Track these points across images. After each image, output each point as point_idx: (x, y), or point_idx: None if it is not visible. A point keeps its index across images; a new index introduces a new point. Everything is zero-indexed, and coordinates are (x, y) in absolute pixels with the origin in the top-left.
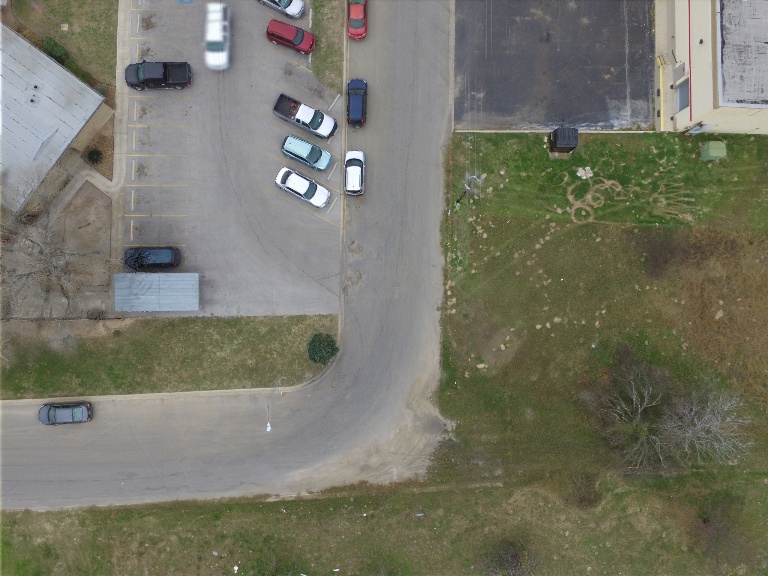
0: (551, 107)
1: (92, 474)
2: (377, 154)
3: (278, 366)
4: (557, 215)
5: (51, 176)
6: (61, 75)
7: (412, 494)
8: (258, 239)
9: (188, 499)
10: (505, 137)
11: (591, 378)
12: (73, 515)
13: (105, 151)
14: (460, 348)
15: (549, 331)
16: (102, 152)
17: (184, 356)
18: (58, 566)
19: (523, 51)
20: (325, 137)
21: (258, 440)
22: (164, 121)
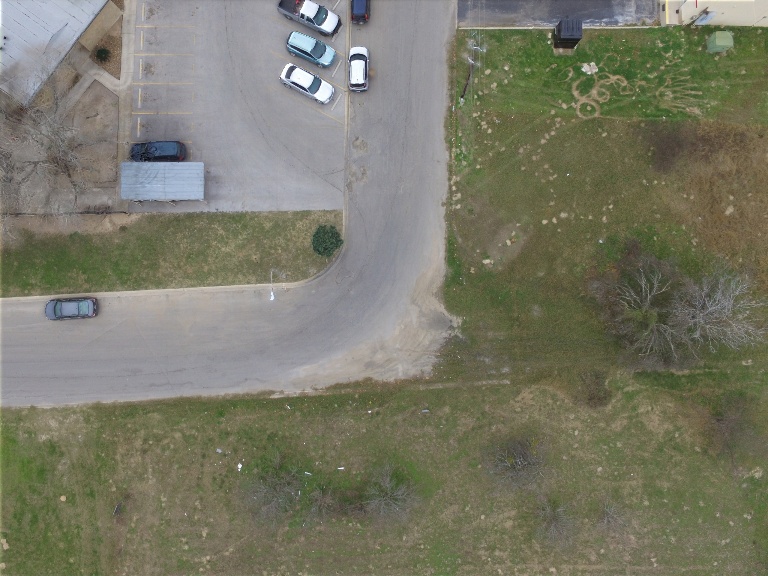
0: (555, 4)
1: (97, 370)
2: (381, 51)
3: (282, 261)
4: (562, 110)
5: (60, 71)
6: None
7: (418, 391)
8: (263, 136)
9: (192, 395)
10: (509, 33)
11: (599, 273)
12: (78, 412)
13: (113, 51)
14: (465, 243)
15: (555, 226)
16: (110, 51)
17: (189, 252)
18: (62, 464)
19: None
20: (329, 33)
21: (262, 336)
22: (171, 21)
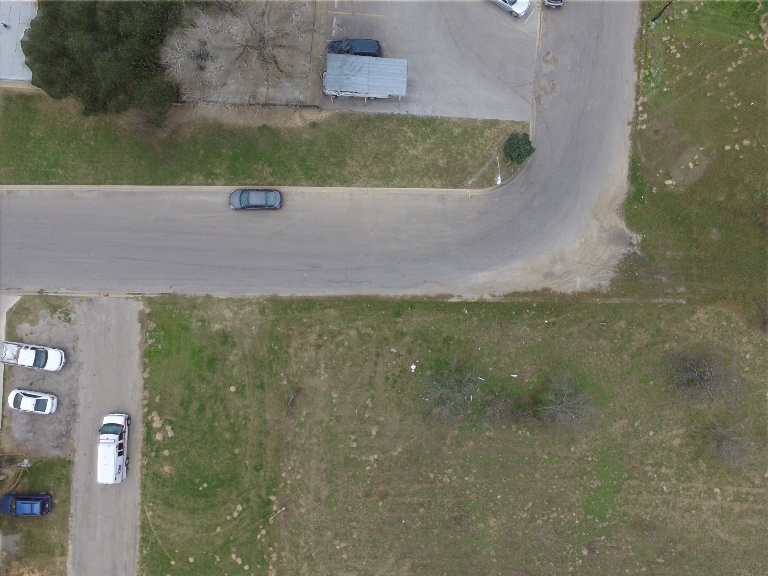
0: None
1: (276, 263)
2: None
3: (468, 167)
4: (749, 41)
5: None
6: None
7: (595, 304)
8: (456, 43)
9: (370, 294)
10: None
11: None
12: (254, 303)
13: None
14: (649, 163)
15: (738, 152)
16: None
17: (376, 151)
18: (234, 354)
19: None
20: None
21: (444, 240)
22: None
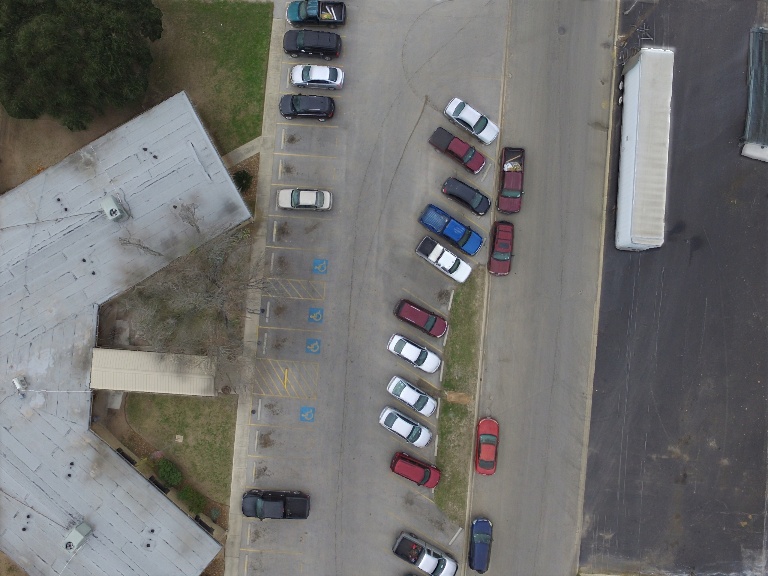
0: (682, 553)
1: None
2: None
3: None
4: None
5: None
6: (179, 519)
7: None
8: None
9: None
10: None
11: None
12: None
13: (215, 575)
14: None
15: None
16: None
17: None
18: None
19: (657, 492)
20: None
21: None
22: (278, 547)
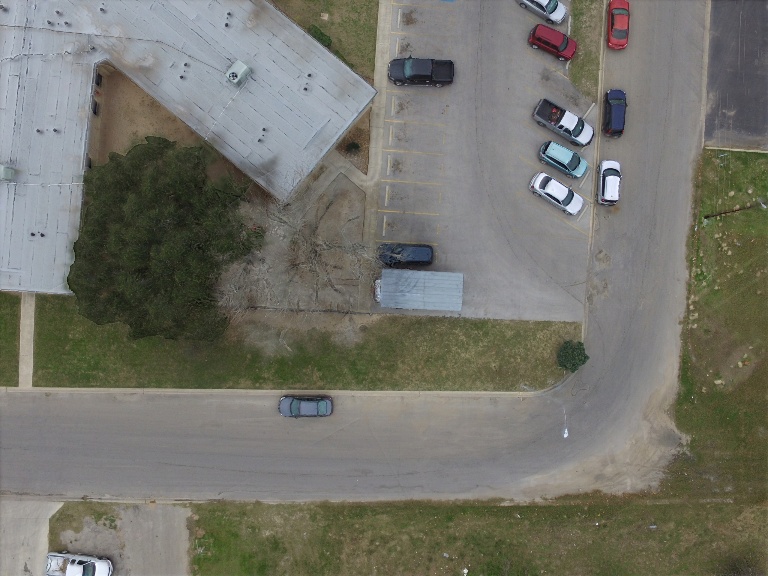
0: None
1: (327, 469)
2: (629, 165)
3: (521, 371)
4: None
5: None
6: (335, 65)
7: (645, 506)
8: (508, 242)
9: (422, 499)
10: (754, 157)
11: None
12: (305, 509)
13: (361, 144)
14: (699, 363)
15: None
16: (359, 145)
17: (428, 355)
18: (285, 560)
19: None
20: (583, 145)
21: (496, 444)
22: (421, 118)
